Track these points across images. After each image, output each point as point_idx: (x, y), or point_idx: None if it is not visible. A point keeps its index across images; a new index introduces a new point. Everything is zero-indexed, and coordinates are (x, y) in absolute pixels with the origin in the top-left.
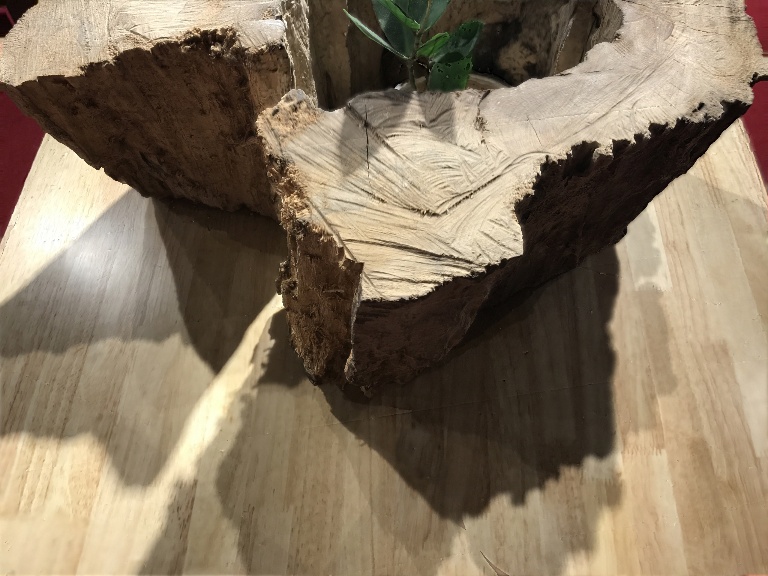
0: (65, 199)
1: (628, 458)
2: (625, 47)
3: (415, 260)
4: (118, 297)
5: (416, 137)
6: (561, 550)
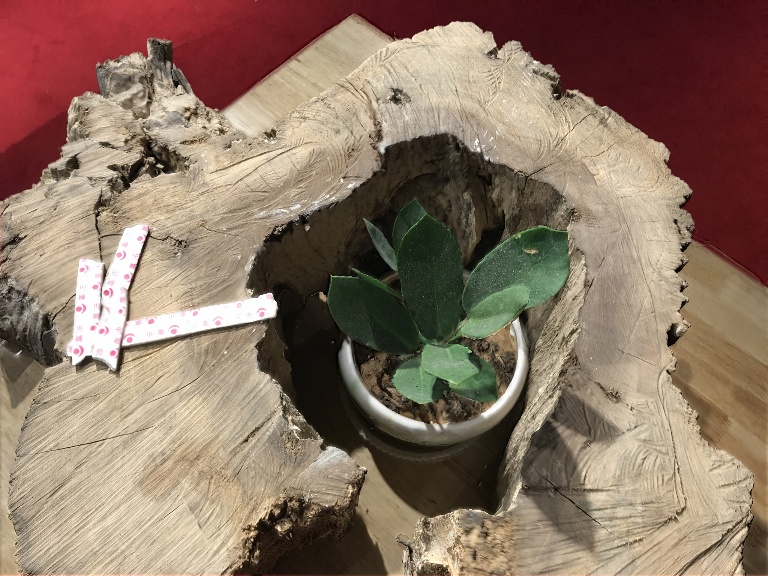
0: None
1: (721, 446)
2: (590, 218)
3: (711, 561)
4: None
5: (597, 459)
6: (759, 554)
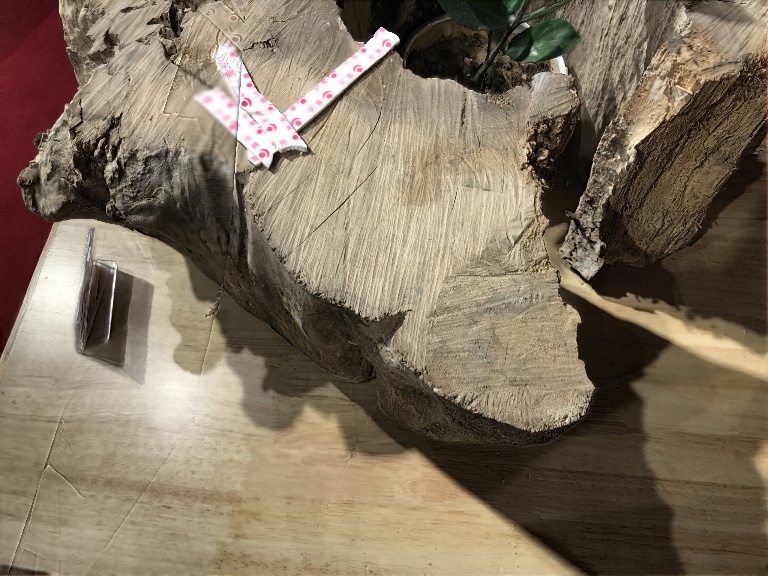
0: (449, 552)
1: None
2: None
3: None
4: (593, 455)
5: None
6: None
